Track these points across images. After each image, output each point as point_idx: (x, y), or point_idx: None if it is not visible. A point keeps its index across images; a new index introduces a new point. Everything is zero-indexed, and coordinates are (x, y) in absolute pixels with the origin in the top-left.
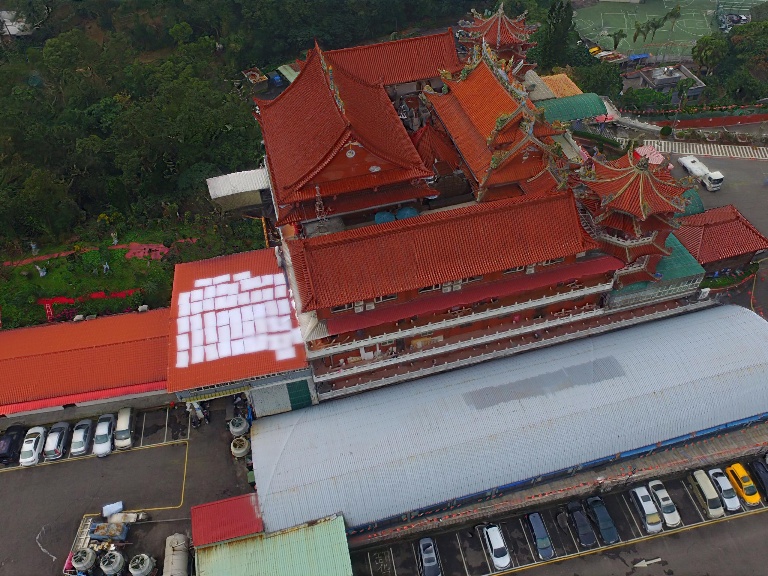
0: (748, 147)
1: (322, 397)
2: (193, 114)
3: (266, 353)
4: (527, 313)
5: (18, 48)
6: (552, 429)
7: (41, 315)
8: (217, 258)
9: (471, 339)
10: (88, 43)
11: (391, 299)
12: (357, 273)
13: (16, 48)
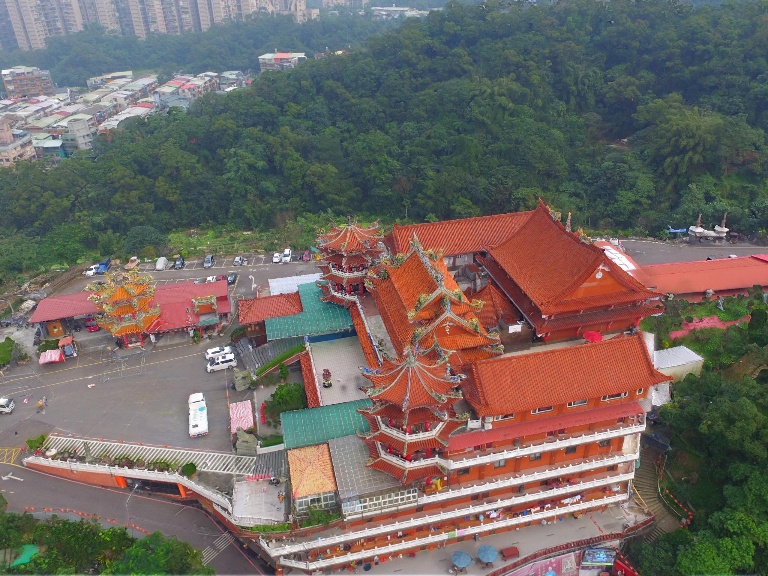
0: None
1: None
2: None
3: None
4: None
5: None
6: None
7: None
8: None
9: None
10: None
11: None
12: None
13: None
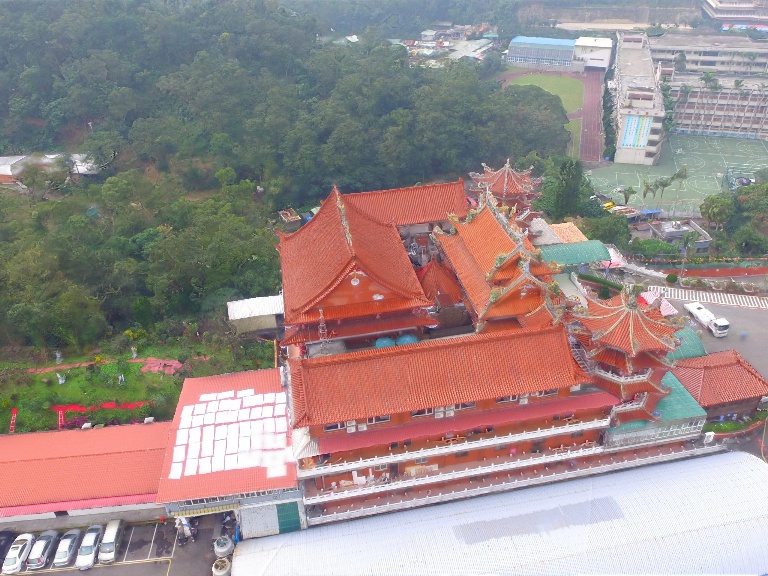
0: (755, 297)
1: (312, 522)
2: (223, 244)
3: (258, 470)
4: (524, 446)
5: (83, 184)
6: (545, 571)
7: (53, 421)
8: (225, 375)
9: (465, 470)
10: (142, 181)
11: (384, 421)
12: (351, 393)
13: (82, 184)
